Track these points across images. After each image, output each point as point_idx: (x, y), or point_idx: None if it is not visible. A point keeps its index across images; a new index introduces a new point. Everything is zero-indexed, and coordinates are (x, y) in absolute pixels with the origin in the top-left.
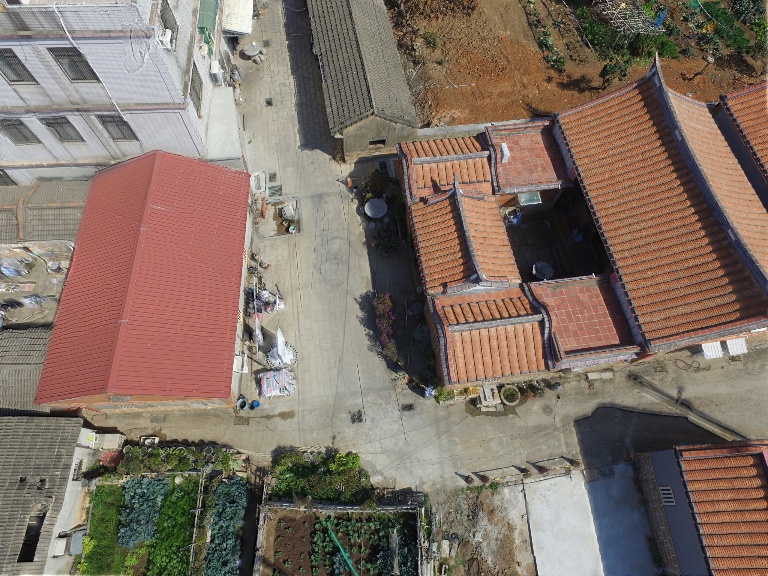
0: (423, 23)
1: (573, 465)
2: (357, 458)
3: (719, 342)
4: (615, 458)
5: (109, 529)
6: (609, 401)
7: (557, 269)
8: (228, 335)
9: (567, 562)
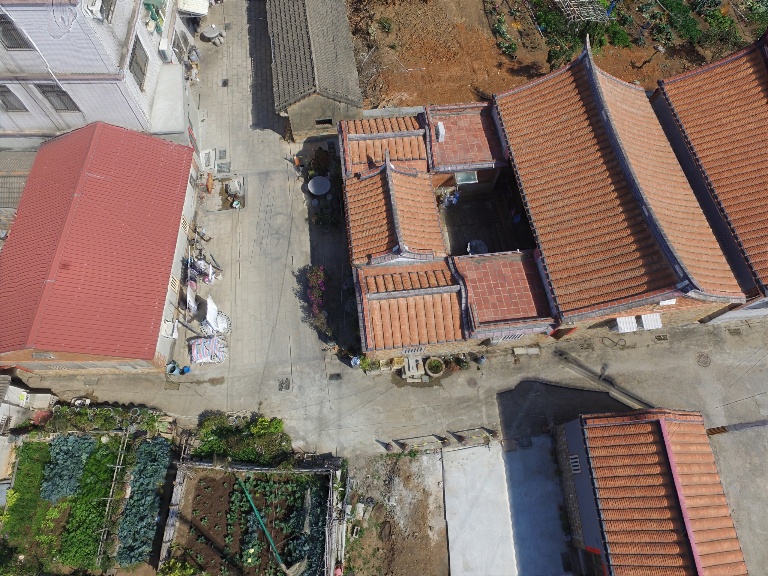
0: (380, 9)
1: (492, 435)
2: (280, 423)
3: (634, 316)
4: (534, 430)
5: (33, 484)
6: (533, 375)
7: (494, 248)
8: (157, 300)
9: (478, 528)
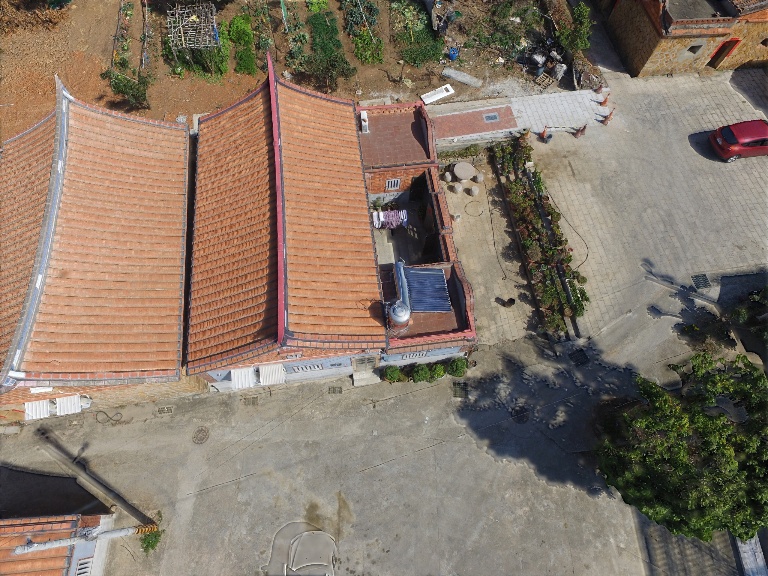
0: None
1: None
2: None
3: (46, 400)
4: None
5: None
6: (1, 459)
7: None
8: None
9: None
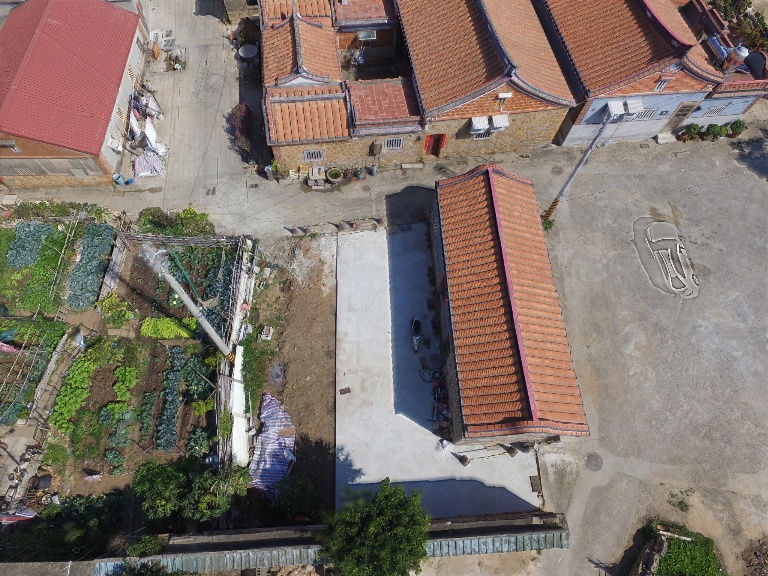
0: None
1: (378, 222)
2: (205, 215)
3: (486, 117)
4: (413, 219)
5: (1, 255)
6: (416, 183)
7: None
8: (103, 115)
9: (362, 283)
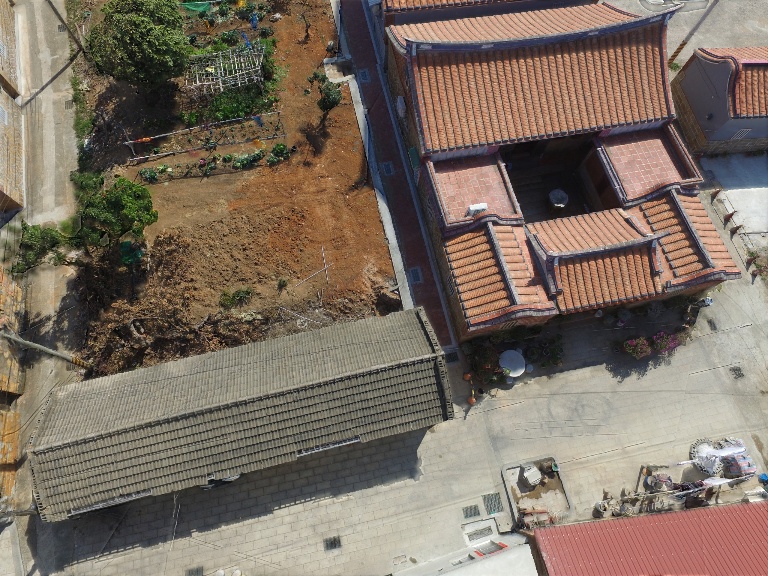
0: (197, 308)
1: None
2: None
3: None
4: (700, 168)
5: None
6: None
7: (538, 189)
8: (762, 510)
9: None
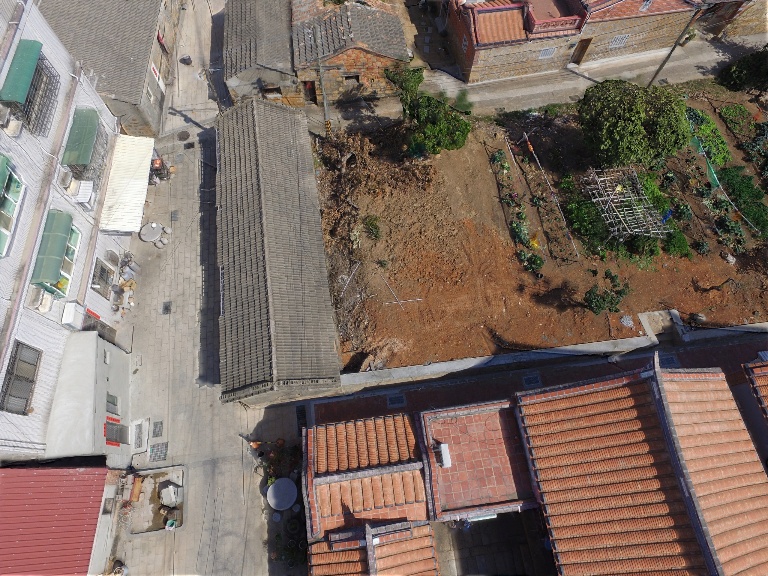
0: (366, 200)
1: None
2: None
3: None
4: None
5: None
6: None
7: None
8: None
9: None
